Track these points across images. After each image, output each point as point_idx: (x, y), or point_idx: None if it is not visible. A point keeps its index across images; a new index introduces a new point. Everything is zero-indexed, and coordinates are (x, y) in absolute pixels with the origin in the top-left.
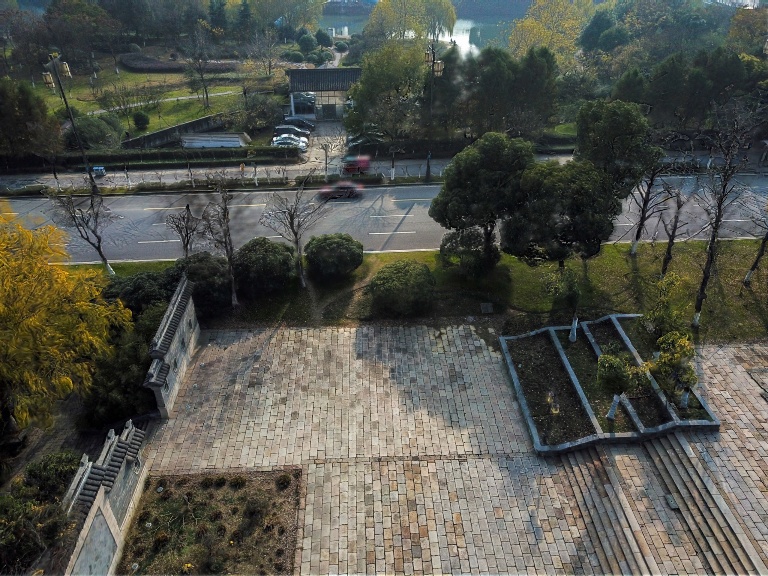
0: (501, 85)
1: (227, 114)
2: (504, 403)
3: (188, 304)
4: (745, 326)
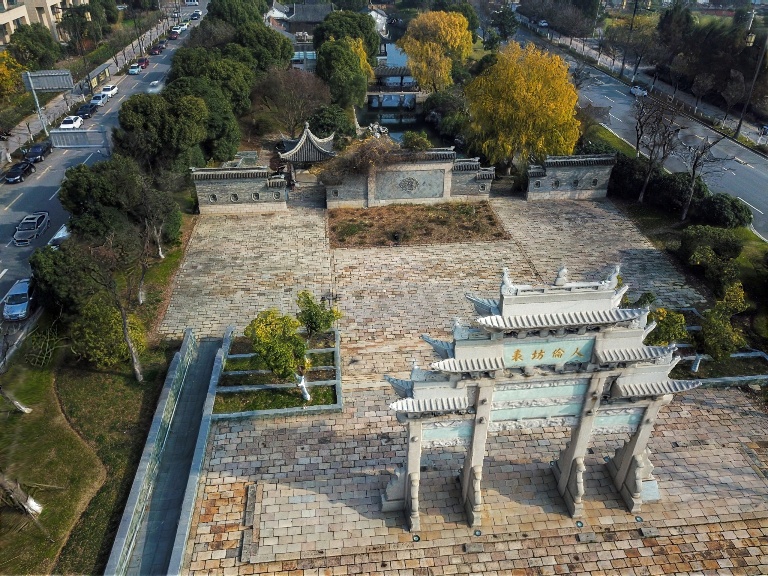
0: None
1: None
2: None
3: (602, 170)
4: None
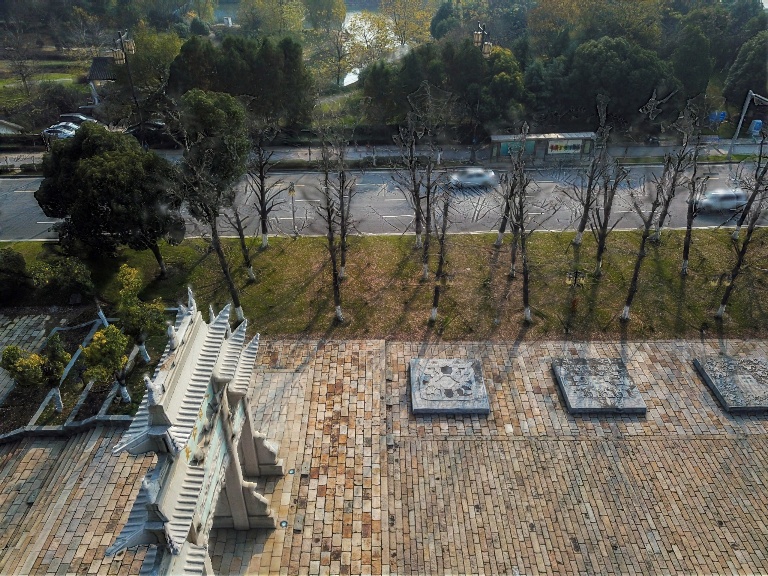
0: (232, 75)
1: (3, 101)
2: None
3: None
4: (291, 322)
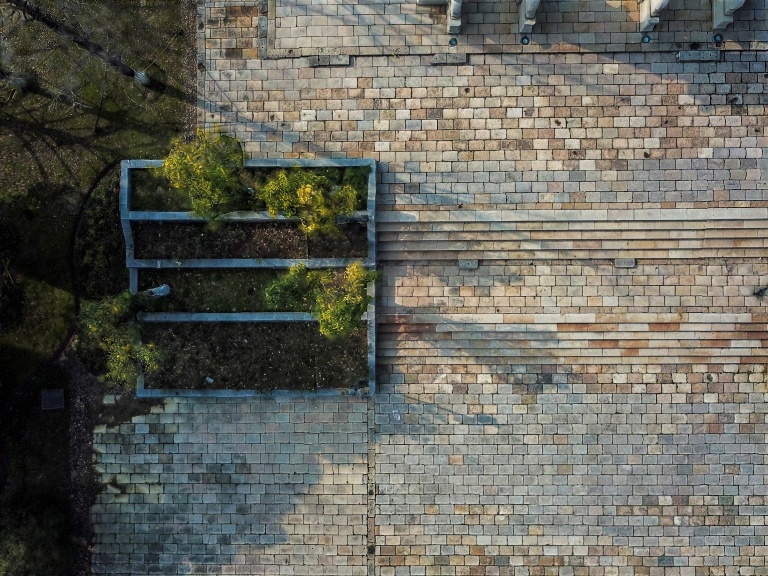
0: None
1: None
2: (277, 414)
3: None
4: None
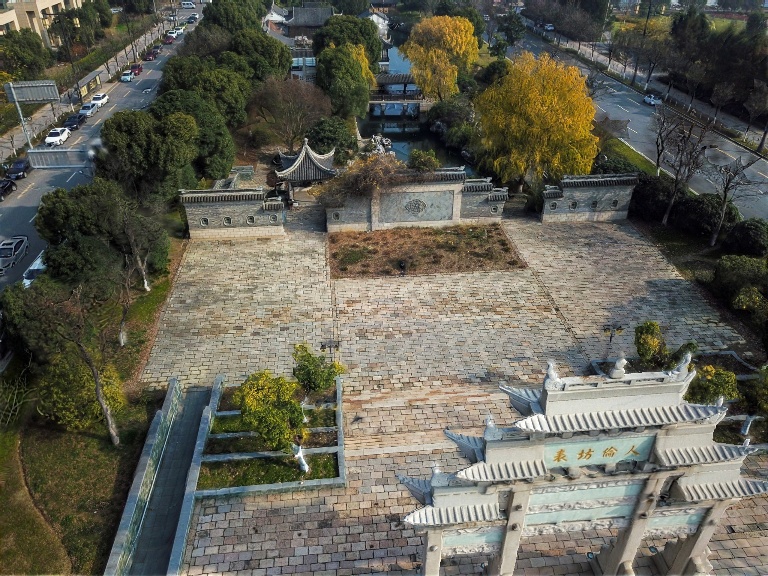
0: None
1: None
2: None
3: (623, 190)
4: None
